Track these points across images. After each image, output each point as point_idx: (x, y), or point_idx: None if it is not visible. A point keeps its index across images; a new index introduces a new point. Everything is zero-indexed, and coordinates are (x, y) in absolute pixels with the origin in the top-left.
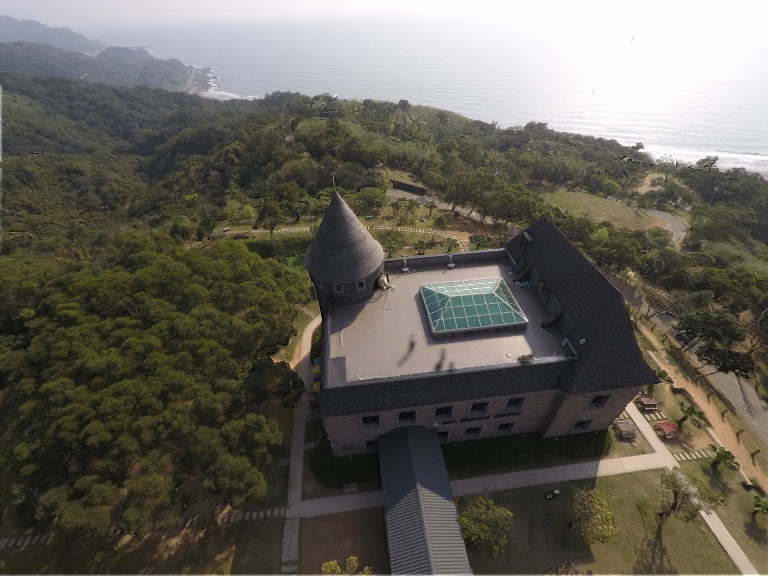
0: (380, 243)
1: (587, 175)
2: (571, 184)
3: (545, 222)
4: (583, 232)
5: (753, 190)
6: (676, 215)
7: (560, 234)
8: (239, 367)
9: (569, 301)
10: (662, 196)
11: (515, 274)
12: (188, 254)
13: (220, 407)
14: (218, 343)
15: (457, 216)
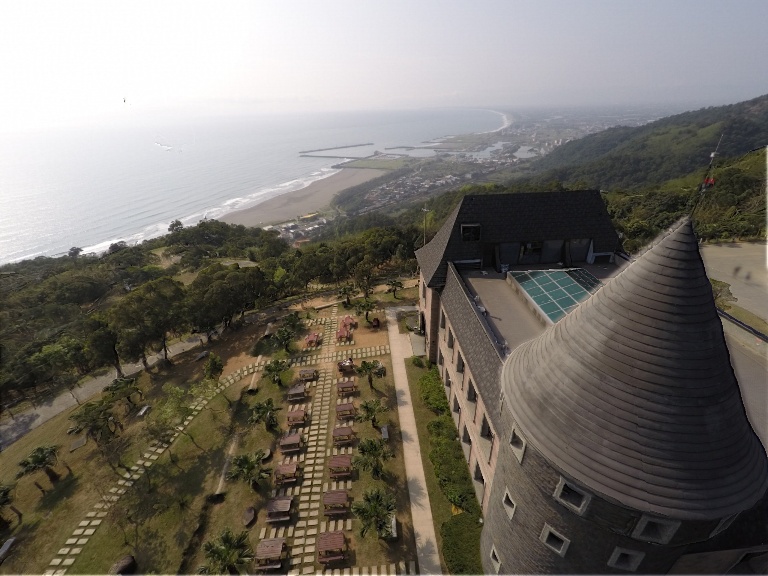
0: (177, 514)
1: (121, 273)
2: None
3: (473, 201)
4: (324, 260)
5: (224, 228)
6: (222, 261)
7: (503, 196)
8: None
9: (570, 230)
10: (195, 256)
11: (485, 270)
12: None
13: None
14: None
15: (170, 365)
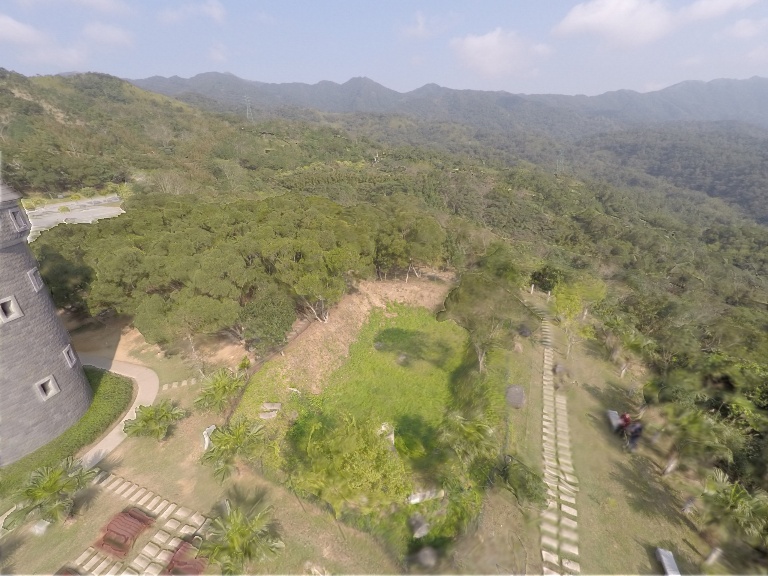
0: None
1: None
2: None
3: None
4: None
5: None
6: None
7: None
8: (92, 259)
9: None
10: None
11: None
12: (325, 225)
13: (44, 236)
14: (134, 244)
15: None
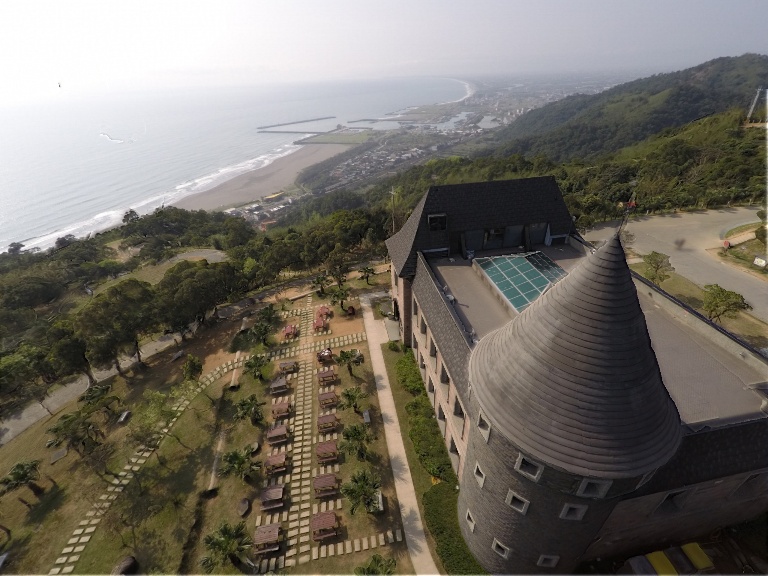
0: (172, 512)
1: (75, 271)
2: (80, 285)
3: (438, 191)
4: (295, 250)
5: (183, 215)
6: (186, 251)
7: (466, 186)
8: None
9: (528, 215)
10: (155, 247)
11: (453, 257)
12: None
13: None
14: None
15: (146, 368)
